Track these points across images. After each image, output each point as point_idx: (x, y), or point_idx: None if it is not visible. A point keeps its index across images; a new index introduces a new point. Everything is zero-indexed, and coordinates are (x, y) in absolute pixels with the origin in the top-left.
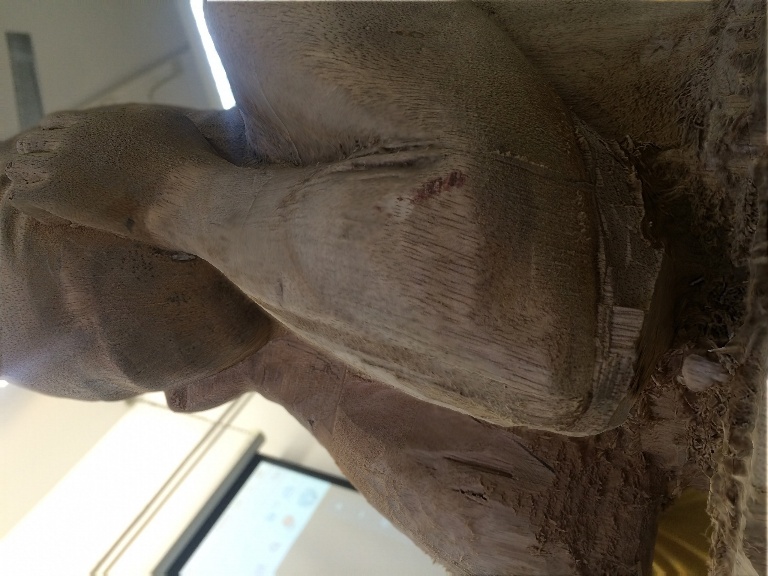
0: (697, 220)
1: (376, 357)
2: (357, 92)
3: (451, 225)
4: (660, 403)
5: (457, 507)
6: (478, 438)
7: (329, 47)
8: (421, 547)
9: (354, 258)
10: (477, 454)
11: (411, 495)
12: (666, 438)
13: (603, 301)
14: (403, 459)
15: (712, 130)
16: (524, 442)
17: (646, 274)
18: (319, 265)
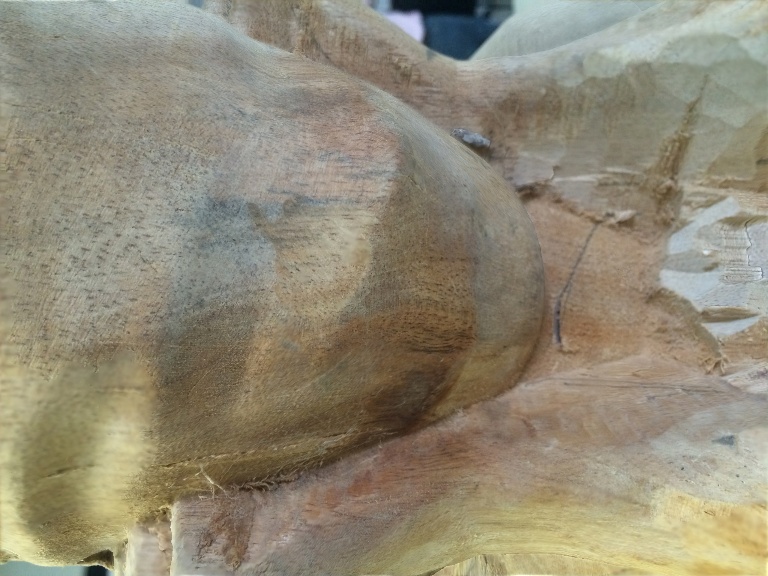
0: None
1: None
2: None
3: None
4: None
5: None
6: None
7: None
8: None
9: None
10: None
11: None
12: None
13: None
14: None
15: None
16: None
17: None
18: None
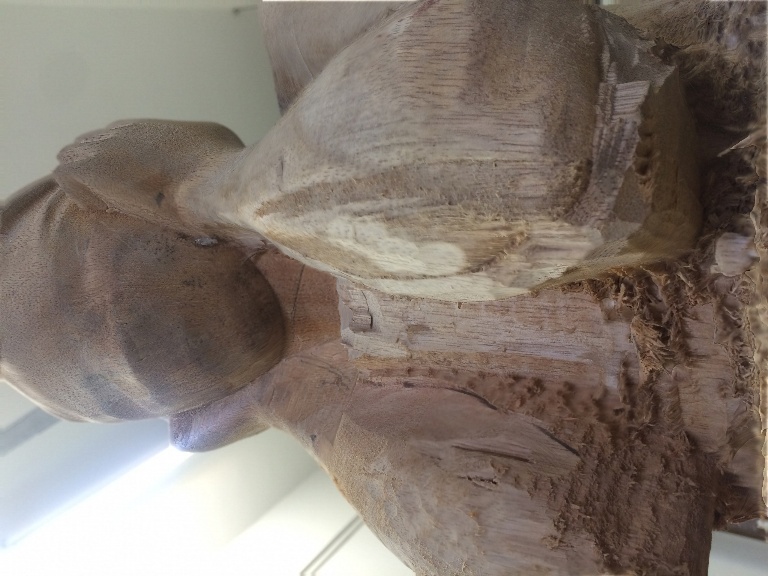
0: (720, 92)
1: (366, 201)
2: None
3: (447, 22)
4: (697, 333)
5: (462, 496)
6: (492, 425)
7: None
8: (419, 567)
9: (351, 89)
10: (490, 440)
11: (411, 493)
12: (710, 391)
13: None
14: (406, 451)
15: (732, 19)
16: (545, 425)
17: (656, 74)
18: (319, 117)
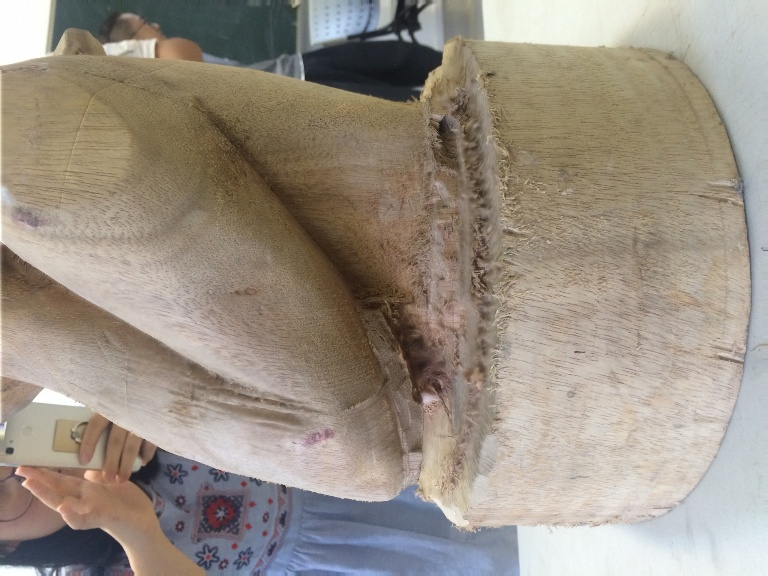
0: (427, 345)
1: None
2: (226, 355)
3: (330, 454)
4: None
5: None
6: None
7: (184, 312)
8: None
9: (264, 464)
10: None
11: None
12: None
13: (404, 451)
14: None
15: (433, 297)
16: None
17: (418, 424)
18: (233, 460)
